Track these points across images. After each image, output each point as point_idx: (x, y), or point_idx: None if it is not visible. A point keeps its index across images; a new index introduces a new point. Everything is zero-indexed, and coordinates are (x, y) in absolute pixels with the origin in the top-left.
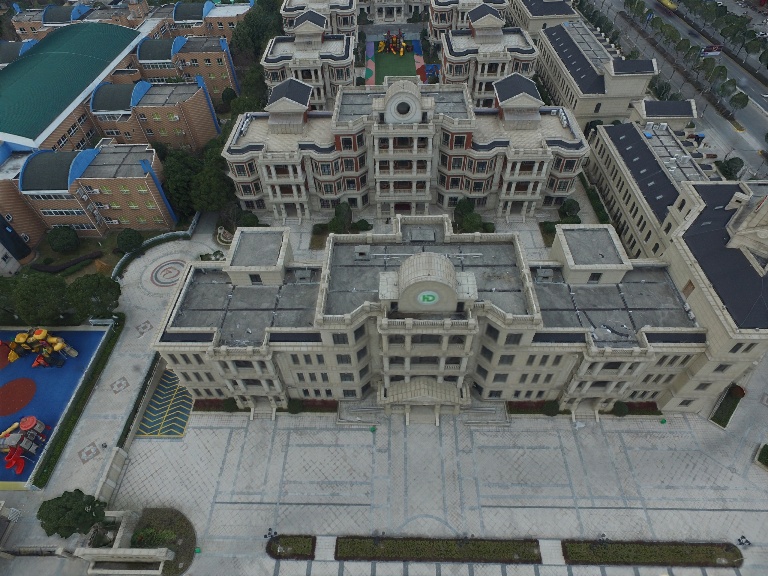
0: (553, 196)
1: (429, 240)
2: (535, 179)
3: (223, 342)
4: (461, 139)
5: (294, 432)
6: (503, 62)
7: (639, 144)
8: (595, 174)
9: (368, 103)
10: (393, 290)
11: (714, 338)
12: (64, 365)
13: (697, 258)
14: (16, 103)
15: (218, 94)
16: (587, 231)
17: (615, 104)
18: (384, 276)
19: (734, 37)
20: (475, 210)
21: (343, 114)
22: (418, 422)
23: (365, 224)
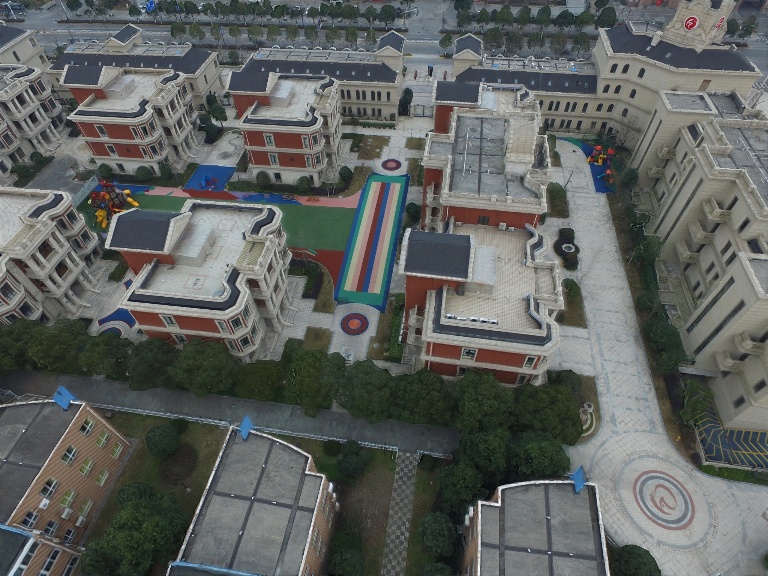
0: None
1: None
2: None
3: None
4: None
5: None
6: None
7: (501, 74)
8: None
9: (478, 178)
10: None
11: (743, 88)
12: None
13: (697, 68)
14: None
15: (108, 479)
16: None
17: None
18: None
19: (283, 15)
20: None
21: None
22: None
23: None
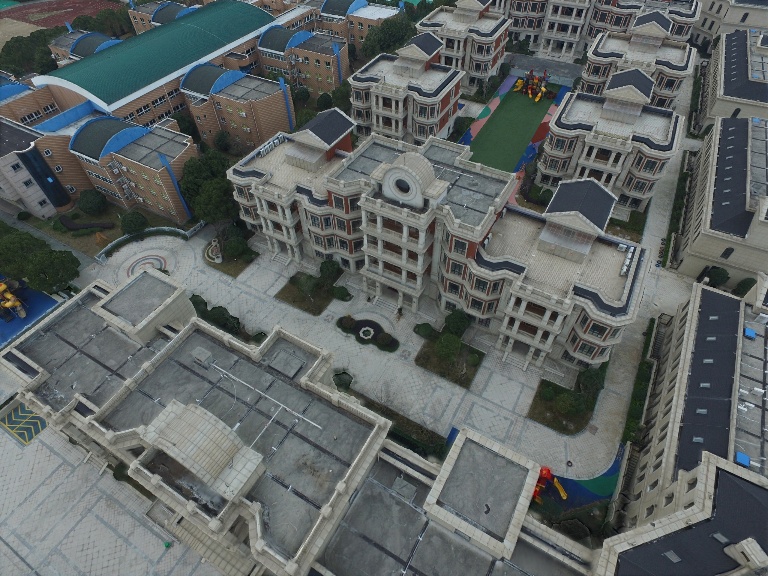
0: (572, 355)
1: (286, 374)
2: (544, 328)
3: (45, 385)
4: (463, 244)
5: (105, 499)
6: (619, 151)
7: (728, 340)
8: (666, 345)
9: None
10: (161, 432)
11: None
12: (10, 321)
13: None
14: (120, 66)
15: None
16: (500, 458)
17: (757, 257)
18: (171, 407)
19: None
20: (475, 327)
21: (351, 168)
22: (214, 565)
23: (341, 293)
